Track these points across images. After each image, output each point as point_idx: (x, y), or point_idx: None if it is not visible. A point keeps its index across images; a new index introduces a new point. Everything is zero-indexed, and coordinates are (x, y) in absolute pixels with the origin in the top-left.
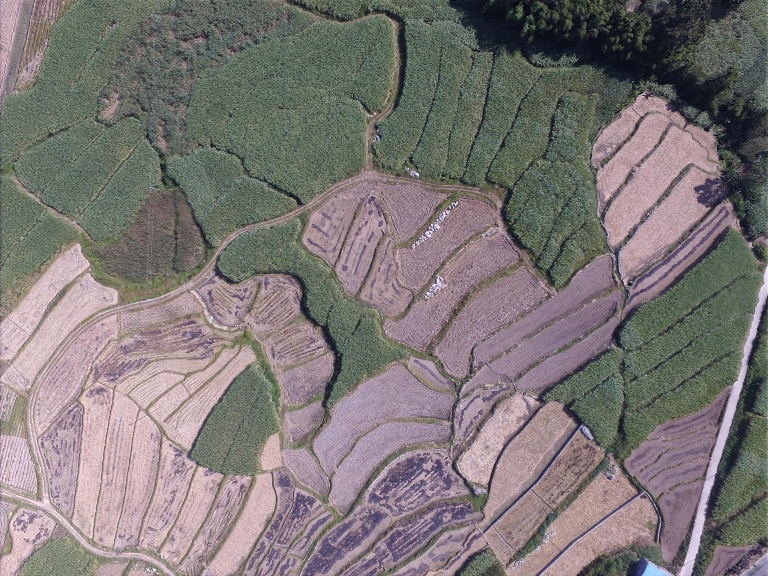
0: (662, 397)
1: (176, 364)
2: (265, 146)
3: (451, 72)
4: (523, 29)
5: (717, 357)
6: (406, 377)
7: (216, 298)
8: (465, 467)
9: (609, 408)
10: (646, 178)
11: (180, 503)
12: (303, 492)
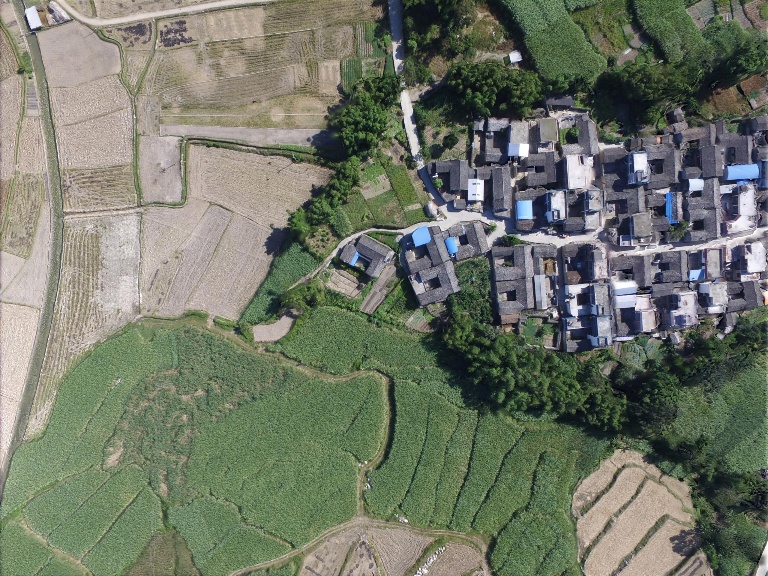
0: None
1: None
2: (261, 497)
3: (438, 429)
4: (505, 408)
5: None
6: None
7: None
8: None
9: None
10: (624, 528)
11: None
12: None
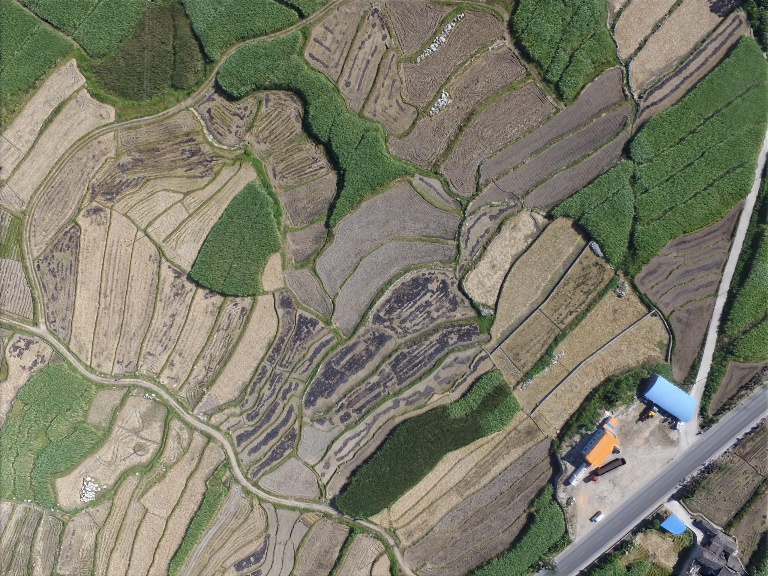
0: (673, 209)
1: (175, 183)
2: None
3: None
4: None
5: (730, 169)
6: (411, 195)
7: (216, 116)
8: (471, 287)
9: (619, 221)
10: None
11: (180, 327)
12: (305, 314)
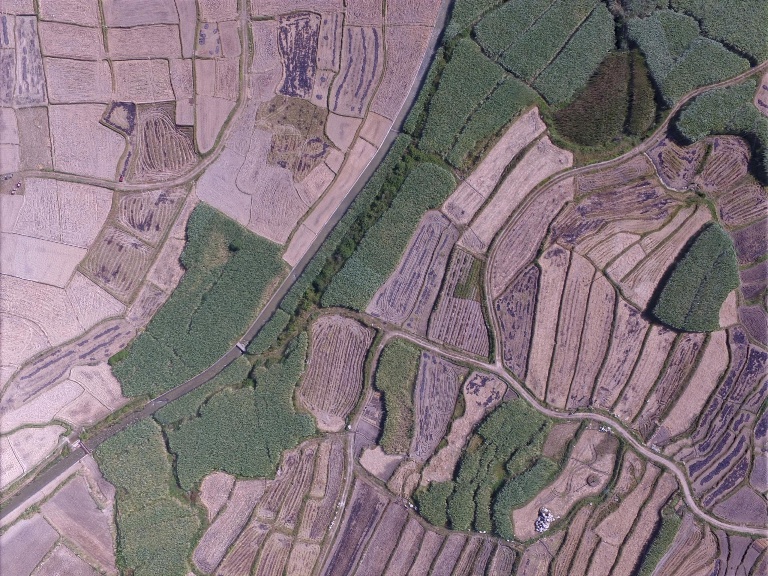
0: None
1: (632, 225)
2: (724, 7)
3: None
4: None
5: None
6: None
7: (666, 160)
8: None
9: None
10: None
11: (632, 363)
12: (757, 348)
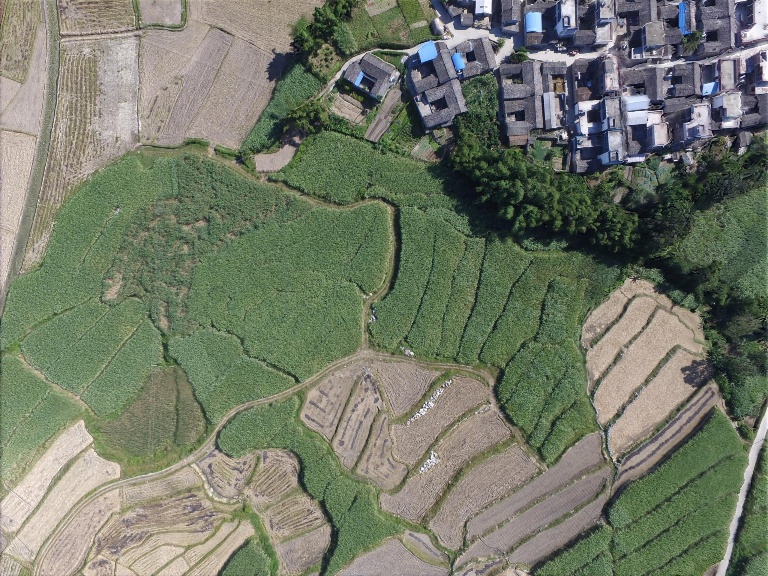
0: (650, 575)
1: (177, 537)
2: (264, 328)
3: (445, 258)
4: (514, 226)
5: (704, 535)
6: (401, 551)
7: (216, 471)
8: None
9: None
10: (634, 359)
11: None
12: None
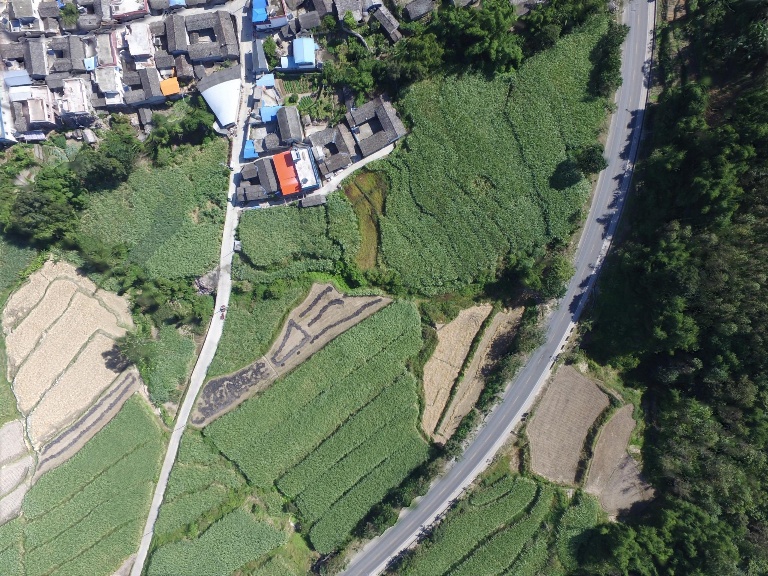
0: (60, 567)
1: None
2: None
3: None
4: None
5: (118, 526)
6: None
7: None
8: None
9: None
10: (54, 344)
11: None
12: None
